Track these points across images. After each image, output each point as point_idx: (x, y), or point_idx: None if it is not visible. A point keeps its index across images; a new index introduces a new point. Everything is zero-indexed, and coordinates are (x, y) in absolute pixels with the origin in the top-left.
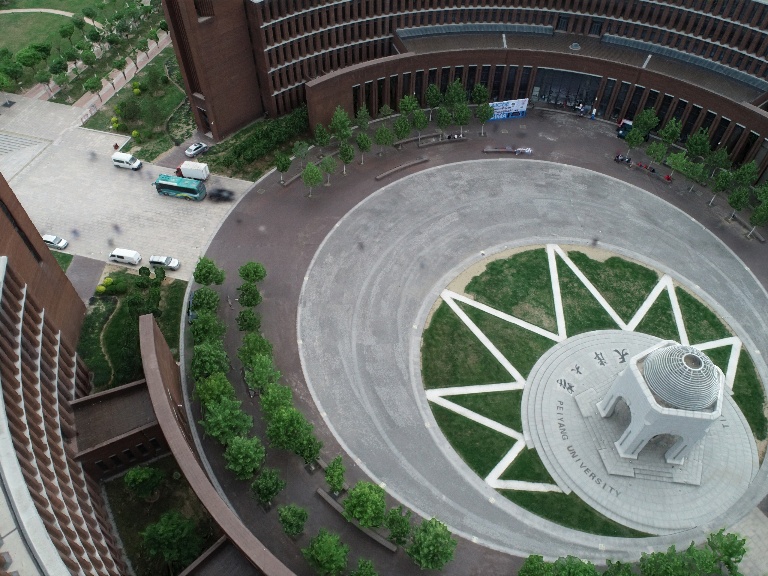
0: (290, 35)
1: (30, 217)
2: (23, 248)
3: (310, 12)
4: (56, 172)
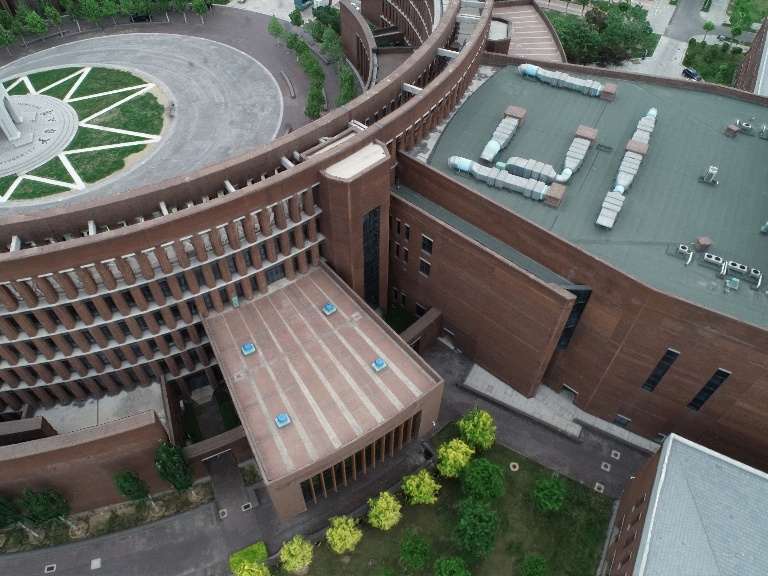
0: None
1: None
2: None
3: None
4: None
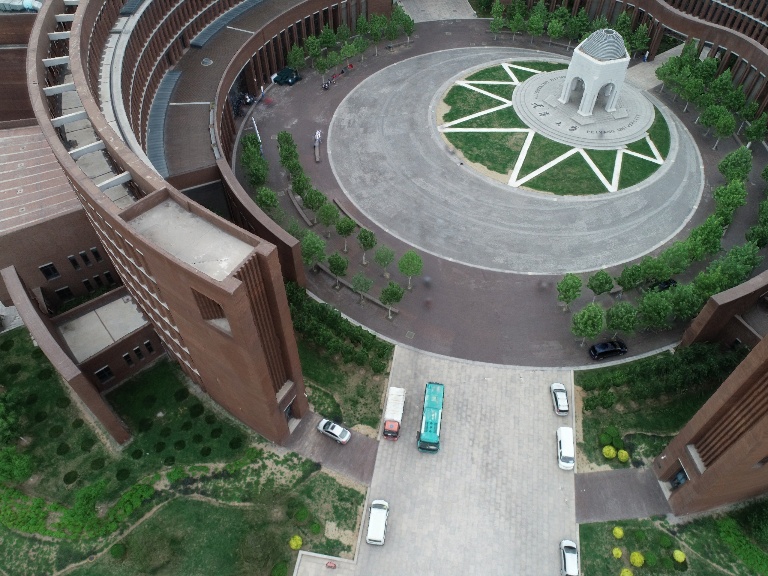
0: None
1: None
2: None
3: None
4: None
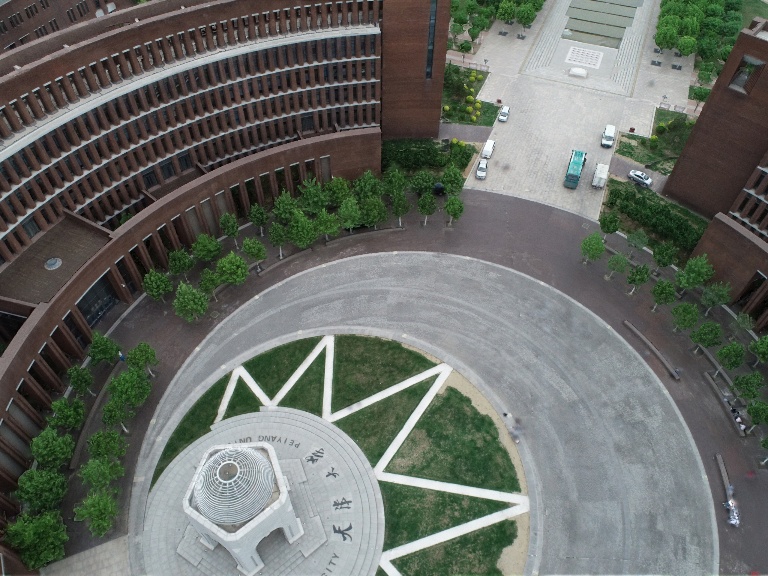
0: None
1: (533, 101)
2: (423, 58)
3: None
4: (590, 105)
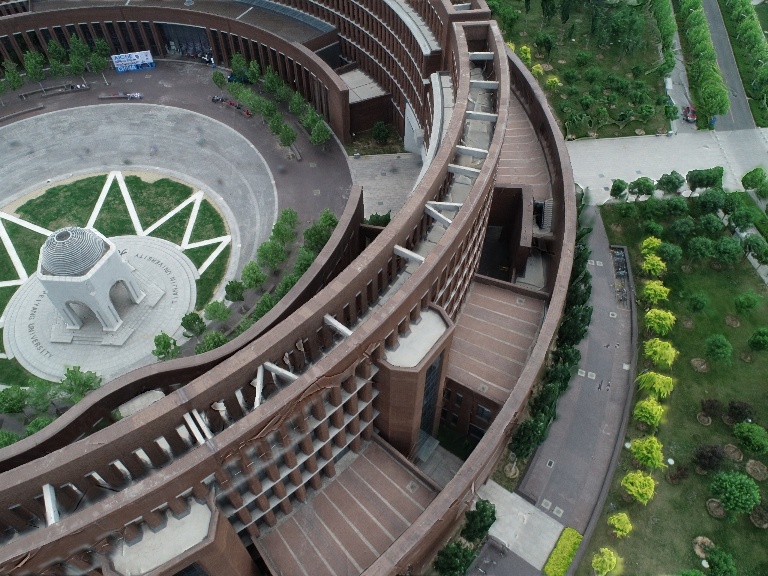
0: None
1: None
2: None
3: None
4: None
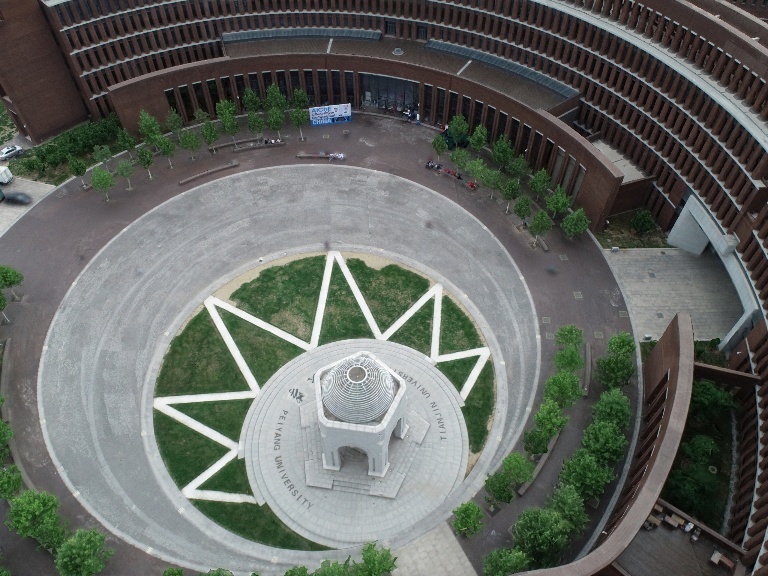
0: (101, 39)
1: None
2: None
3: (119, 16)
4: None
